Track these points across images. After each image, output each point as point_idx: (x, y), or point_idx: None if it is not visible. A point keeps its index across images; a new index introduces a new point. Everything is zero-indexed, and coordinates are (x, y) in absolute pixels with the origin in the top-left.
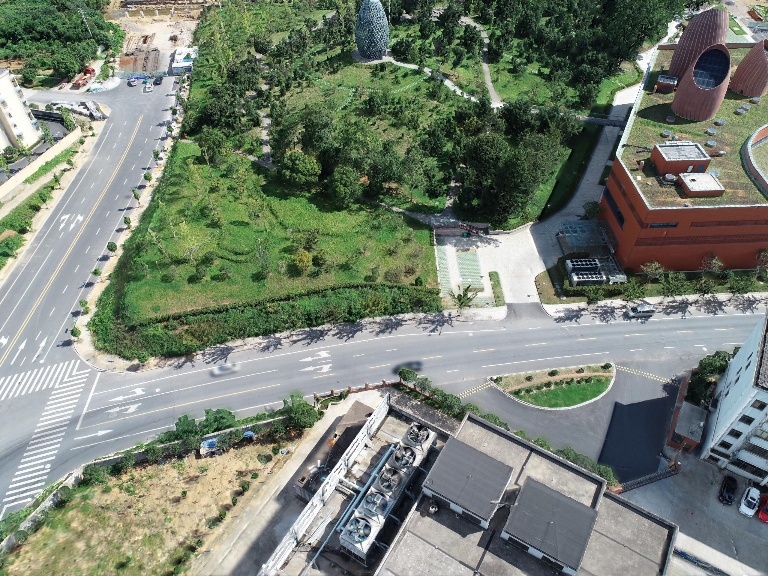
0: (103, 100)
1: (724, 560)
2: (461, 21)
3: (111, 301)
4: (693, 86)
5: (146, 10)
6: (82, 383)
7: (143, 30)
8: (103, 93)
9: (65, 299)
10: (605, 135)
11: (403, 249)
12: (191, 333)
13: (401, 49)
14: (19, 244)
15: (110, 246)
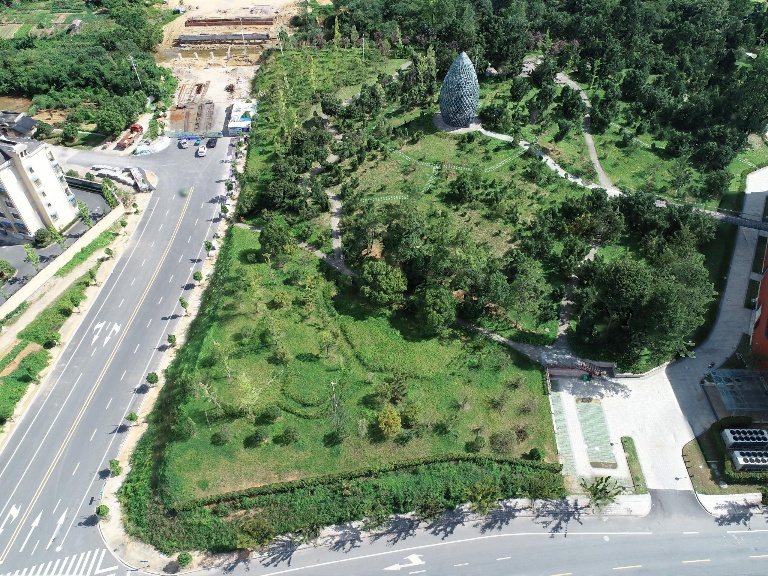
0: (150, 165)
1: None
2: (555, 78)
3: (148, 463)
4: None
5: (200, 50)
6: None
7: (197, 77)
8: (150, 156)
9: (92, 450)
10: (742, 235)
11: None
12: (248, 532)
13: (491, 116)
14: (43, 363)
15: (150, 378)
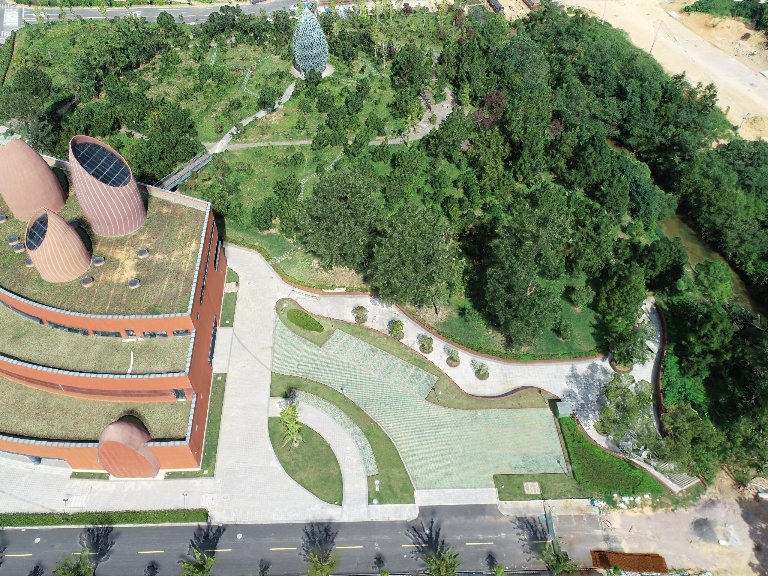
0: None
1: None
2: (423, 124)
3: None
4: None
5: None
6: (0, 36)
7: None
8: None
9: None
10: None
11: None
12: None
13: None
14: (119, 6)
15: None
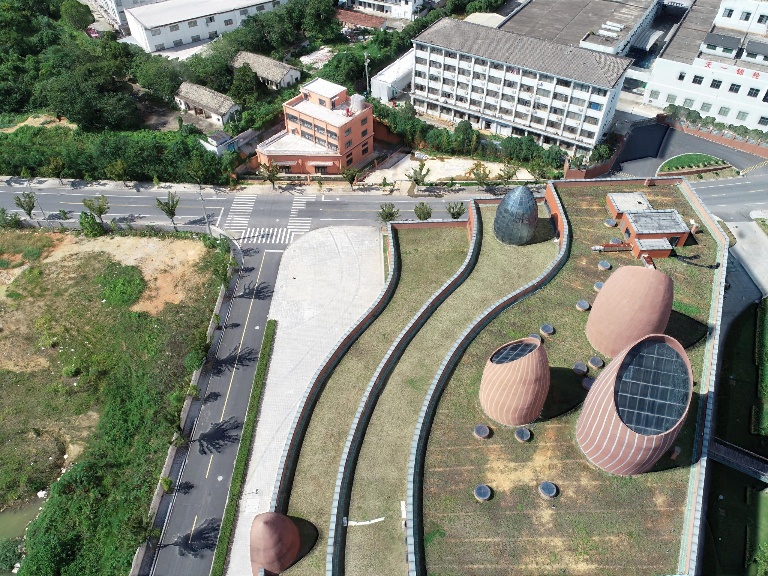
0: None
1: None
2: None
3: None
4: None
5: None
6: None
7: None
8: None
9: None
10: None
11: None
12: None
13: None
14: None
15: None
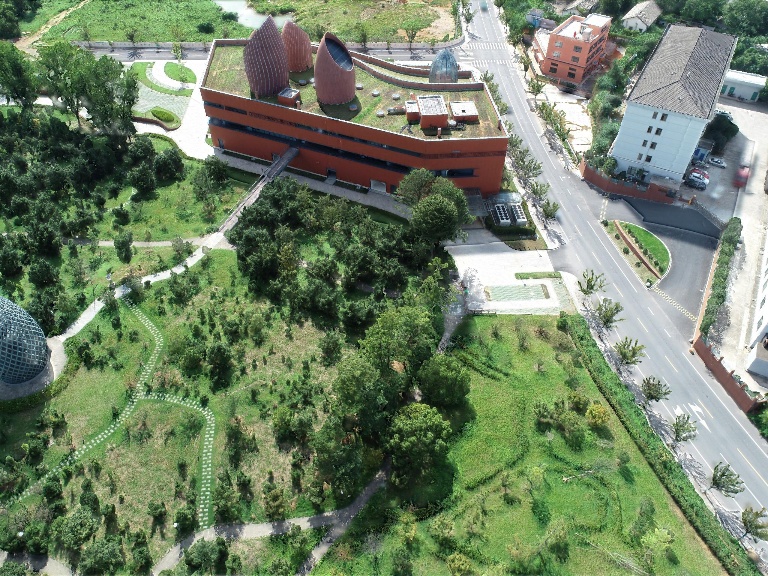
0: None
1: (742, 197)
2: None
3: None
4: (346, 73)
5: None
6: None
7: None
8: None
9: None
10: None
11: (512, 339)
12: None
13: (44, 318)
14: None
15: None
